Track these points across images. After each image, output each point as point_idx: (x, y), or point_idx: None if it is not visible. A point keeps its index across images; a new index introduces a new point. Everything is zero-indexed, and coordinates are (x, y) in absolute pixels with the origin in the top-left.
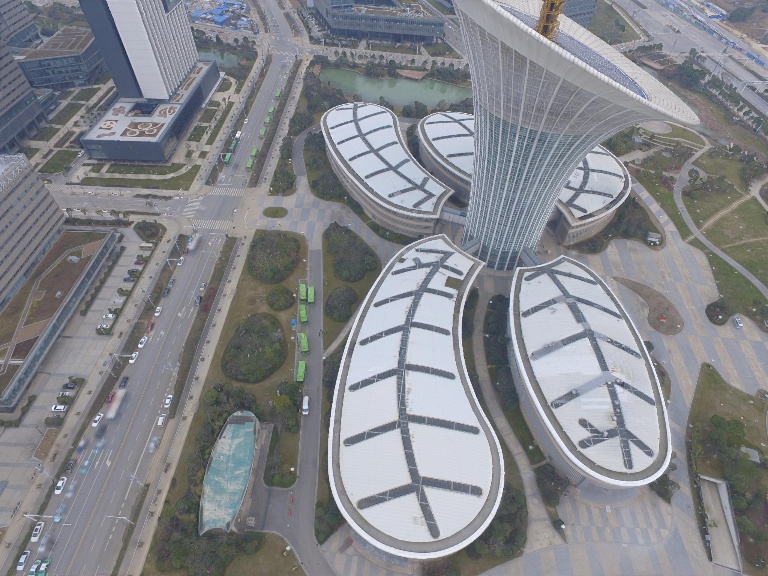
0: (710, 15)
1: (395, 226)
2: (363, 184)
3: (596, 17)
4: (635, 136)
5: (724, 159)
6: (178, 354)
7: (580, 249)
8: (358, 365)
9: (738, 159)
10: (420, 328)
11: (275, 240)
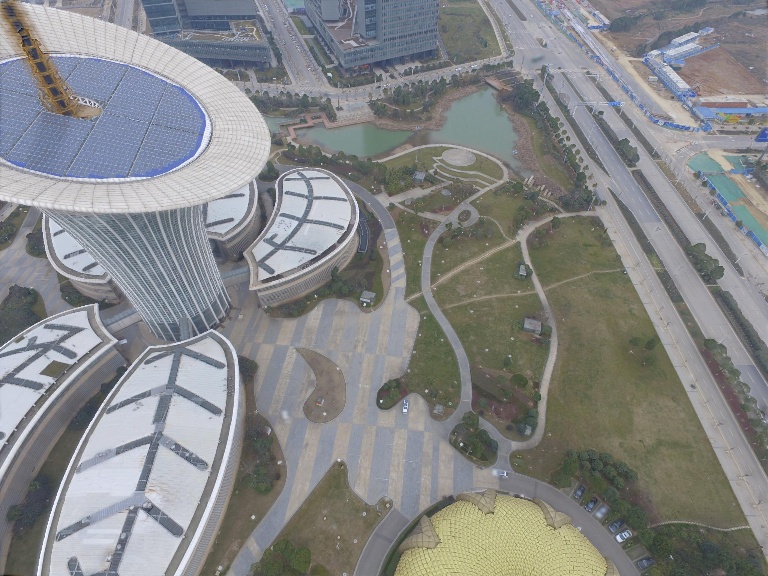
0: (589, 26)
1: (80, 289)
2: (50, 242)
3: (464, 32)
4: (418, 172)
5: (508, 196)
6: None
7: (276, 313)
8: None
9: (524, 196)
10: None
11: None
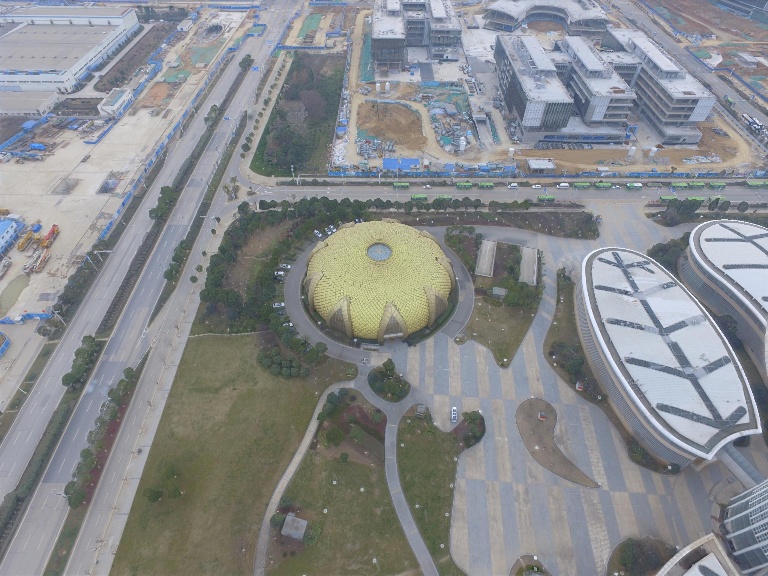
0: None
1: None
2: None
3: None
4: None
5: None
6: None
7: None
8: None
9: None
10: None
11: None
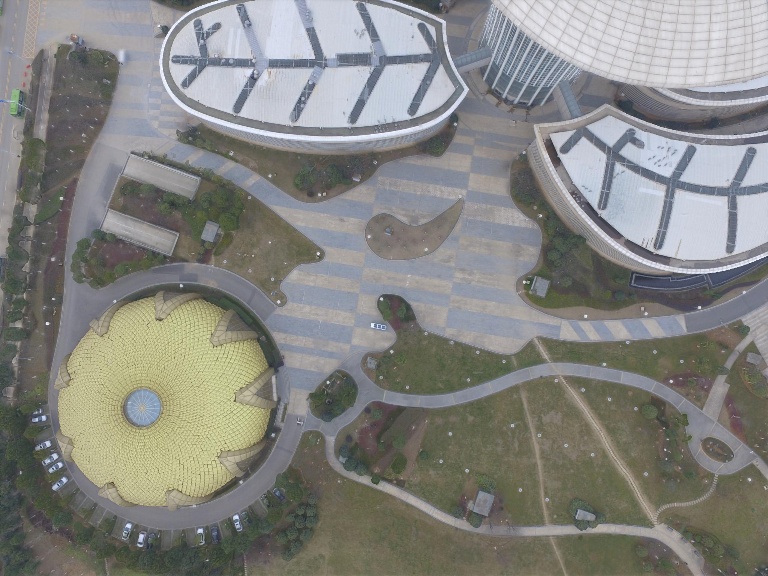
0: None
1: None
2: None
3: None
4: None
5: None
6: None
7: (516, 167)
8: None
9: None
10: None
11: None
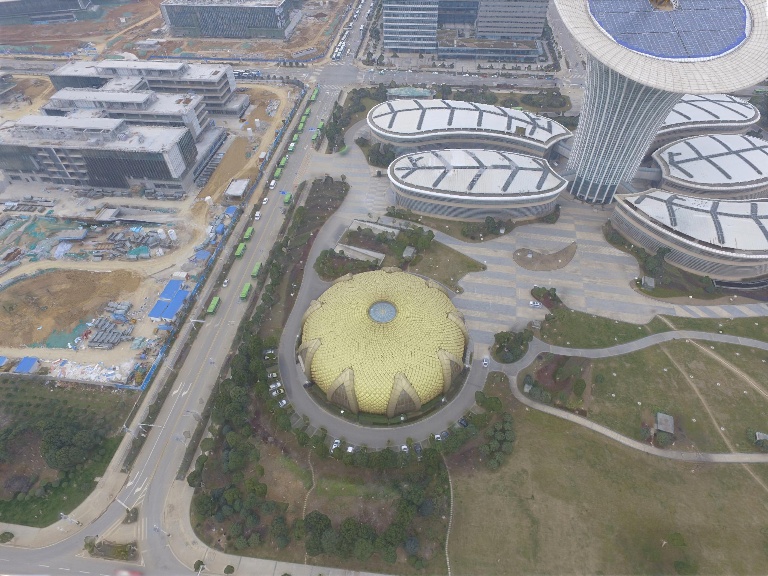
0: None
1: None
2: None
3: None
4: None
5: None
6: (470, 84)
7: None
8: (455, 101)
9: None
10: (479, 114)
11: (549, 89)
